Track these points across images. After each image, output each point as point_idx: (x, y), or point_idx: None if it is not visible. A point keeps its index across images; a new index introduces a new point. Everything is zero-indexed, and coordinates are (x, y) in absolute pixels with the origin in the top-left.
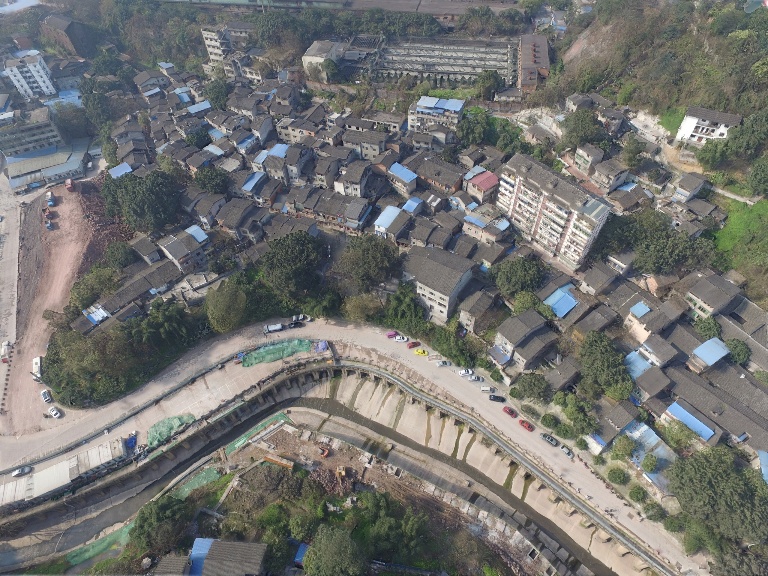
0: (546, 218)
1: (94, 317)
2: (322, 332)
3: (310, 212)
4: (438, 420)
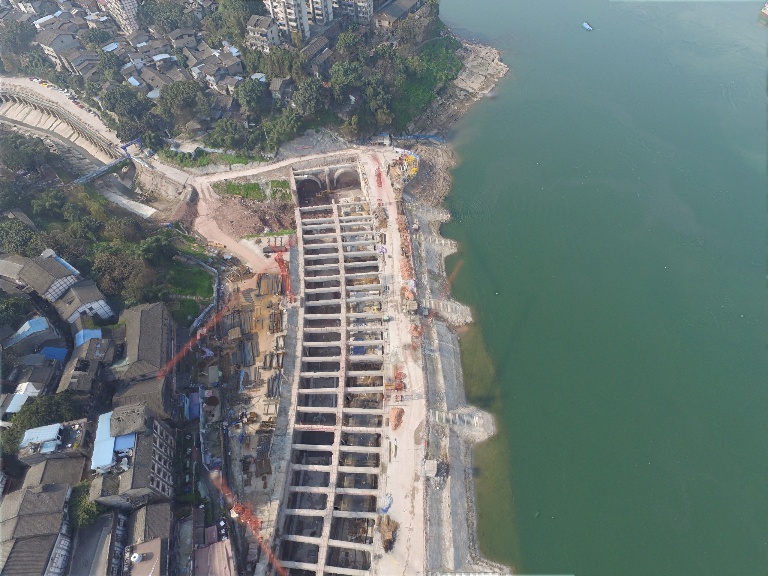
0: (115, 8)
1: None
2: None
3: (4, 22)
4: (47, 116)
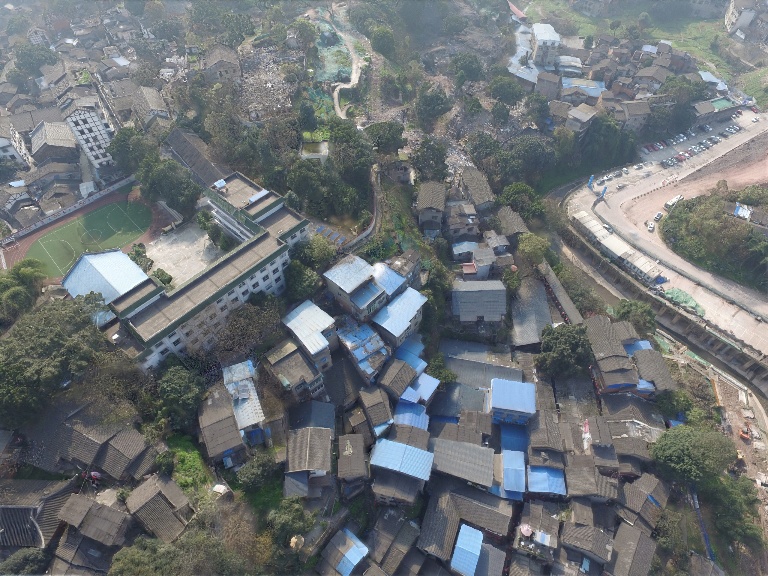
0: None
1: (740, 211)
2: None
3: None
4: None
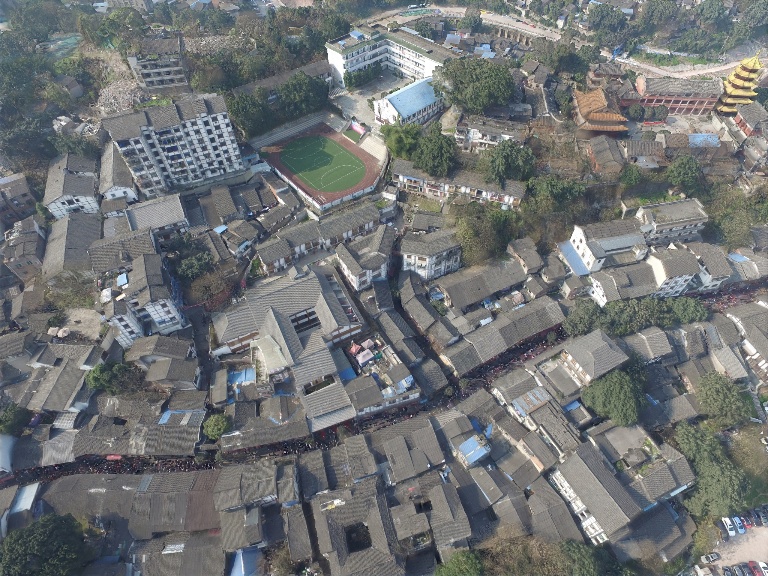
0: None
1: None
2: None
3: None
4: None
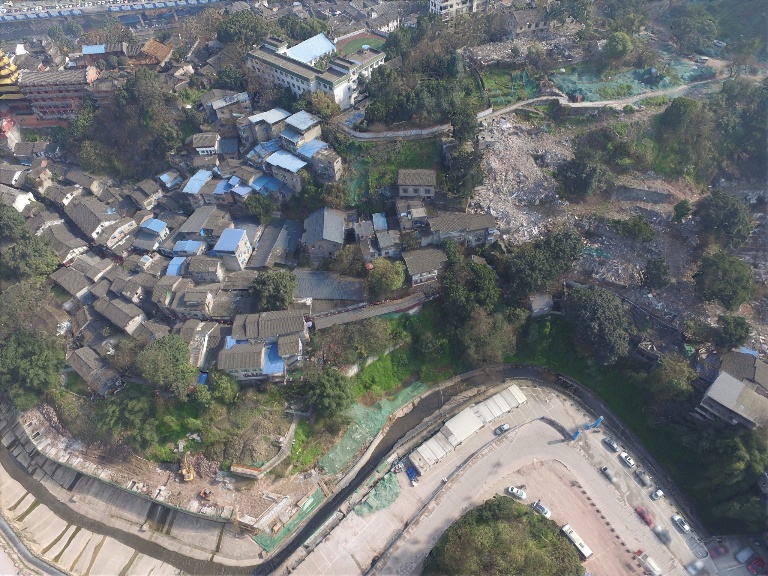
0: None
1: None
2: None
3: None
4: (78, 569)
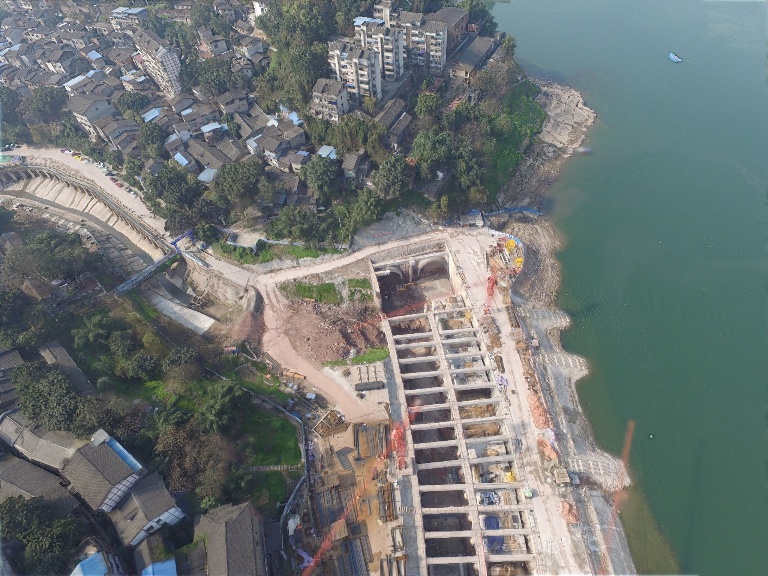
0: None
1: None
2: (22, 152)
3: None
4: (81, 194)
